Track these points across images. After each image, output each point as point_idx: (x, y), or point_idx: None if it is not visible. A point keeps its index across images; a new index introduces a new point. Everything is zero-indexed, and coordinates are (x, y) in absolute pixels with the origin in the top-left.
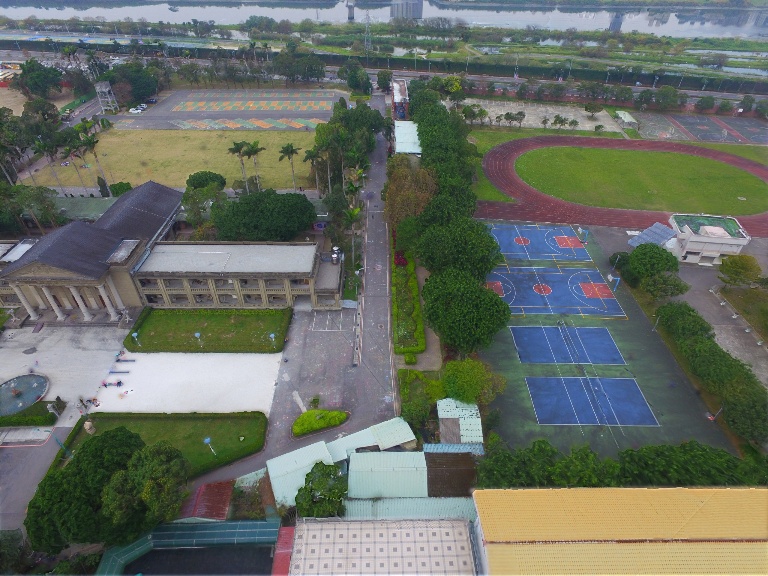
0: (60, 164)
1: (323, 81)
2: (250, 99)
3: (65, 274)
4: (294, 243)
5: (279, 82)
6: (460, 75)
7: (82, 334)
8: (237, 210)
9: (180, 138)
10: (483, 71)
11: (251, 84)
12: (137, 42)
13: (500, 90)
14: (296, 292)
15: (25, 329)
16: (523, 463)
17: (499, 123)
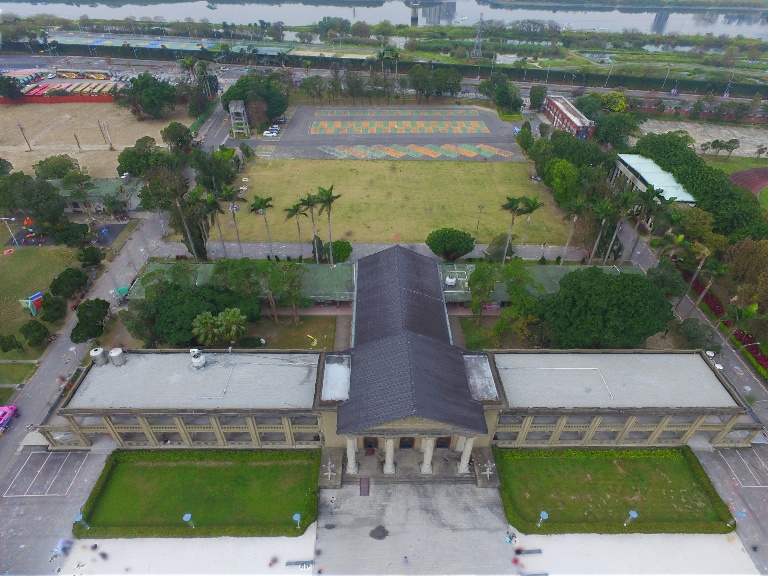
0: (228, 209)
1: (457, 96)
2: (389, 118)
3: (437, 425)
4: (670, 351)
5: (407, 97)
6: (617, 90)
7: (432, 498)
8: (585, 304)
9: (347, 171)
10: (625, 84)
11: (380, 99)
12: (227, 48)
13: (667, 108)
14: (704, 428)
15: (347, 489)
16: None
17: (704, 152)
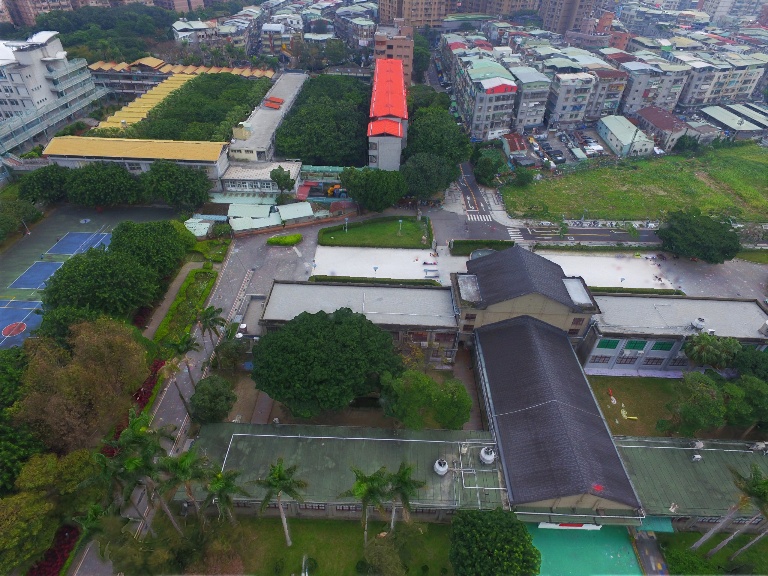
0: None
1: None
2: None
3: None
4: None
5: None
6: None
7: None
8: None
9: None
10: None
11: None
12: None
13: None
14: None
15: None
16: (185, 177)
17: None
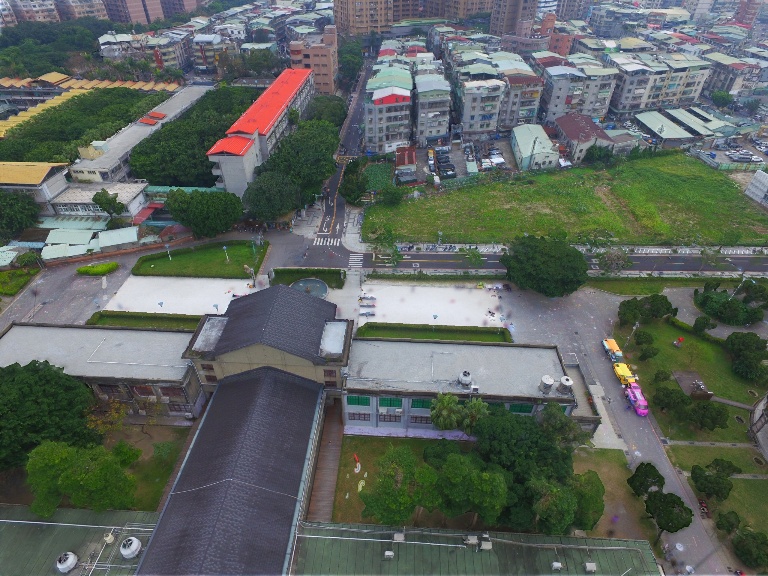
0: None
1: None
2: None
3: None
4: None
5: None
6: None
7: None
8: None
9: None
10: None
11: None
12: None
13: None
14: None
15: None
16: (2, 202)
17: None
